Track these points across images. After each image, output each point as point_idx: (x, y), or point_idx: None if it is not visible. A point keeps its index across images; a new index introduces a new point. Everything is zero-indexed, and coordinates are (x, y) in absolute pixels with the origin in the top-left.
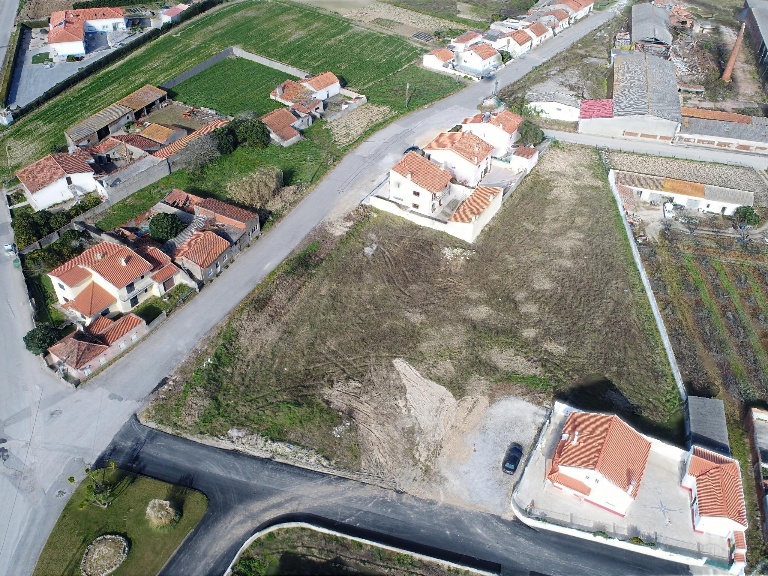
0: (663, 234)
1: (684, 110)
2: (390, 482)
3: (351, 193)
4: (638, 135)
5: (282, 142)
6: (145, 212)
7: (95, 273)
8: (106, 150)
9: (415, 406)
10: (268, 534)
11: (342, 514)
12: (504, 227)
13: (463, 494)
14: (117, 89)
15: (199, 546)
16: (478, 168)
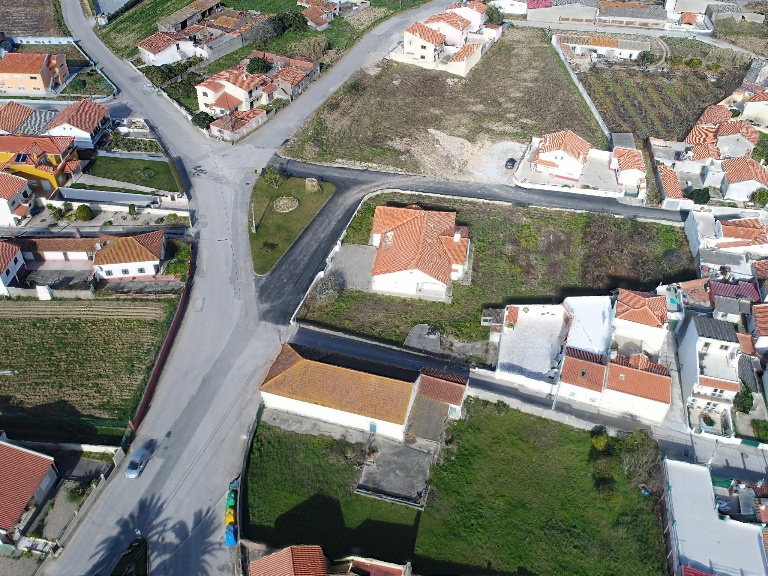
0: (591, 69)
1: (601, 3)
2: (440, 176)
3: (376, 53)
4: (570, 20)
5: (317, 27)
6: (237, 64)
7: (228, 83)
8: (193, 32)
9: (447, 147)
10: (376, 195)
11: (416, 188)
12: (485, 68)
13: (485, 178)
14: (176, 3)
15: (338, 201)
16: (462, 35)
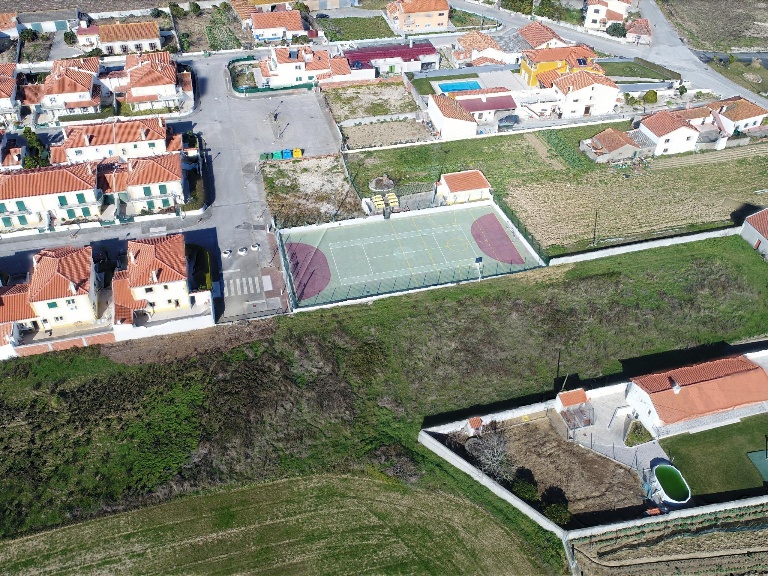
0: None
1: None
2: None
3: None
4: None
5: None
6: None
7: (613, 0)
8: None
9: None
10: None
11: None
12: None
13: None
14: None
15: None
16: None
